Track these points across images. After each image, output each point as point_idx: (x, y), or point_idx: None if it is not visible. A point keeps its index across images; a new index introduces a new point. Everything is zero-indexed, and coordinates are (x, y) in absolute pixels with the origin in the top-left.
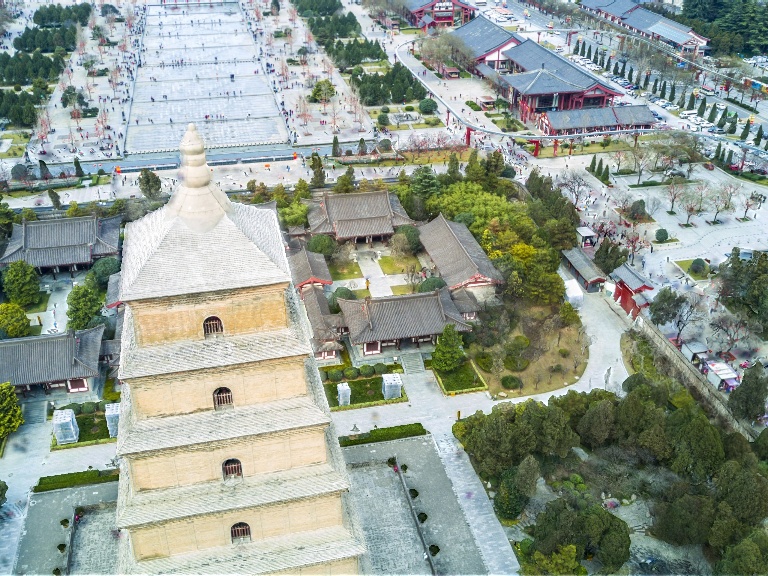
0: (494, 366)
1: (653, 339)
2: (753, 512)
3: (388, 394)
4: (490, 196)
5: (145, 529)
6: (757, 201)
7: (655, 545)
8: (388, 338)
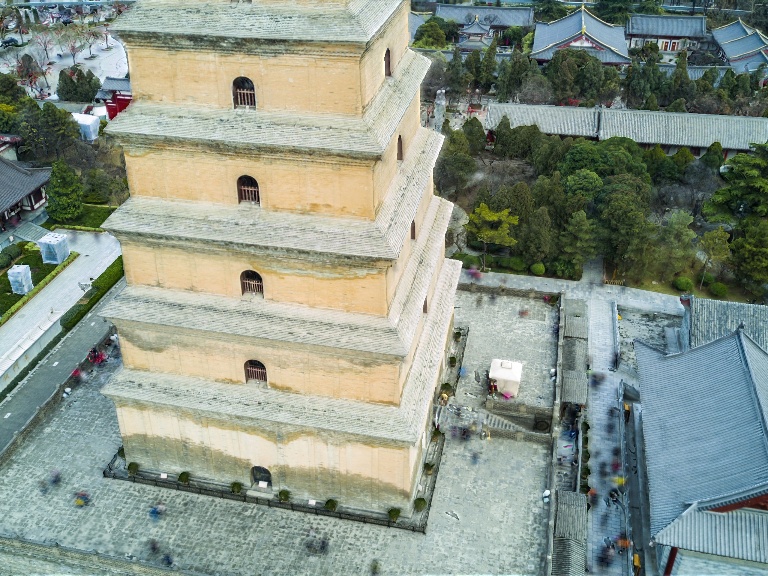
0: (116, 187)
1: None
2: None
3: (60, 256)
4: None
5: (376, 163)
6: None
7: None
8: None
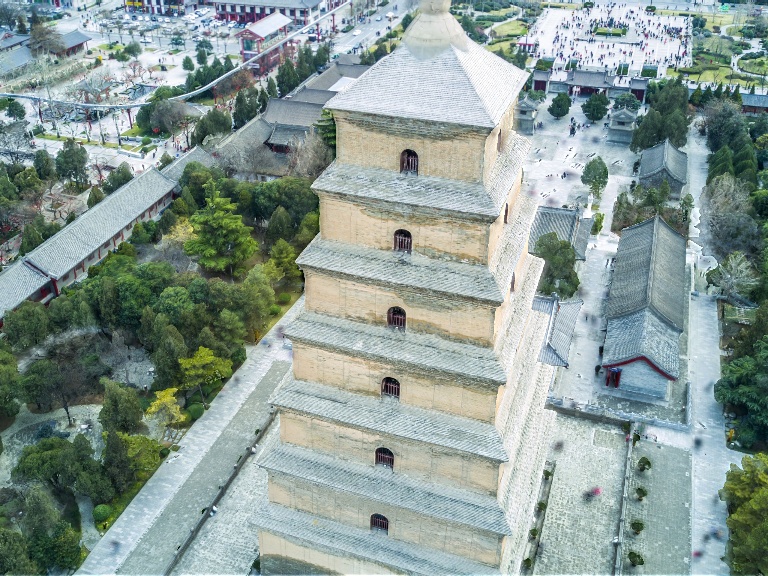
0: None
1: None
2: None
3: None
4: None
5: None
6: None
7: (2, 471)
8: None
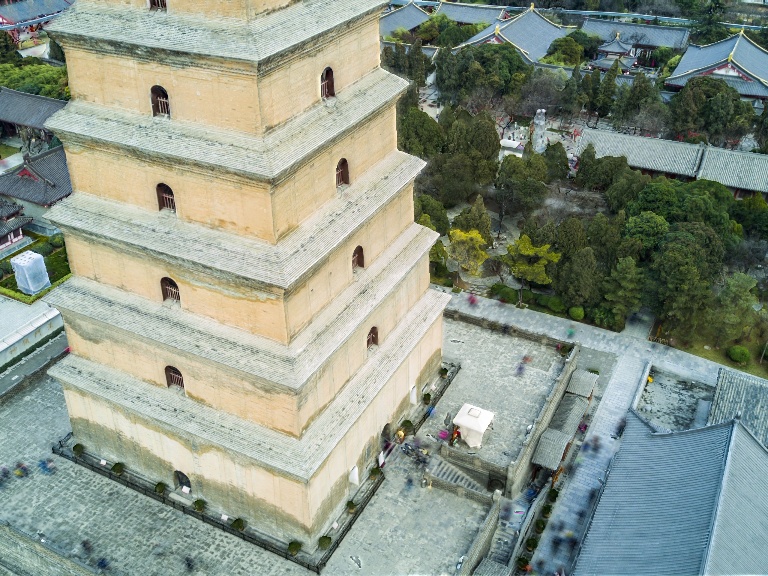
0: None
1: None
2: (494, 147)
3: None
4: (33, 67)
5: (281, 186)
6: None
7: None
8: None
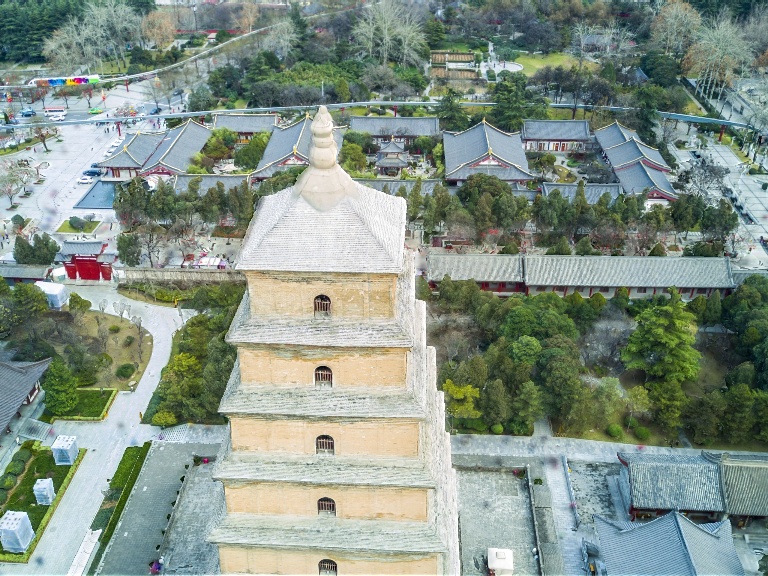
0: (104, 370)
1: (148, 276)
2: None
3: (72, 458)
4: None
5: None
6: (24, 166)
7: None
8: (7, 423)
